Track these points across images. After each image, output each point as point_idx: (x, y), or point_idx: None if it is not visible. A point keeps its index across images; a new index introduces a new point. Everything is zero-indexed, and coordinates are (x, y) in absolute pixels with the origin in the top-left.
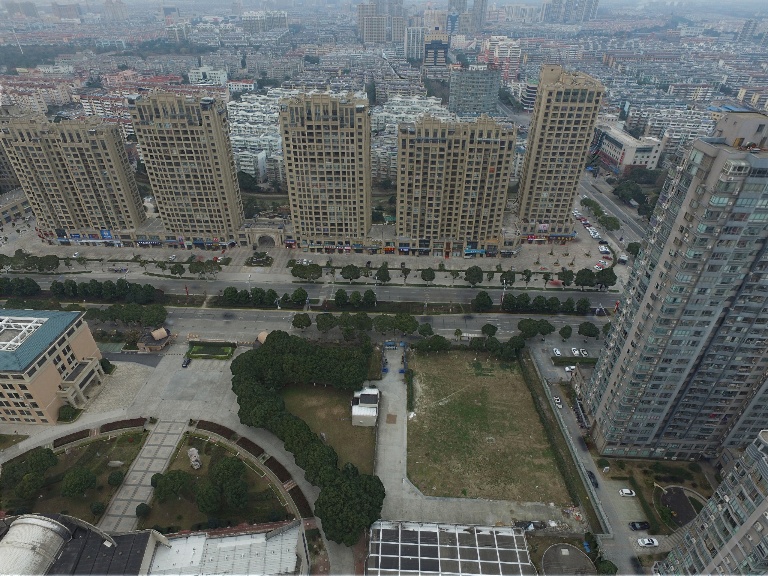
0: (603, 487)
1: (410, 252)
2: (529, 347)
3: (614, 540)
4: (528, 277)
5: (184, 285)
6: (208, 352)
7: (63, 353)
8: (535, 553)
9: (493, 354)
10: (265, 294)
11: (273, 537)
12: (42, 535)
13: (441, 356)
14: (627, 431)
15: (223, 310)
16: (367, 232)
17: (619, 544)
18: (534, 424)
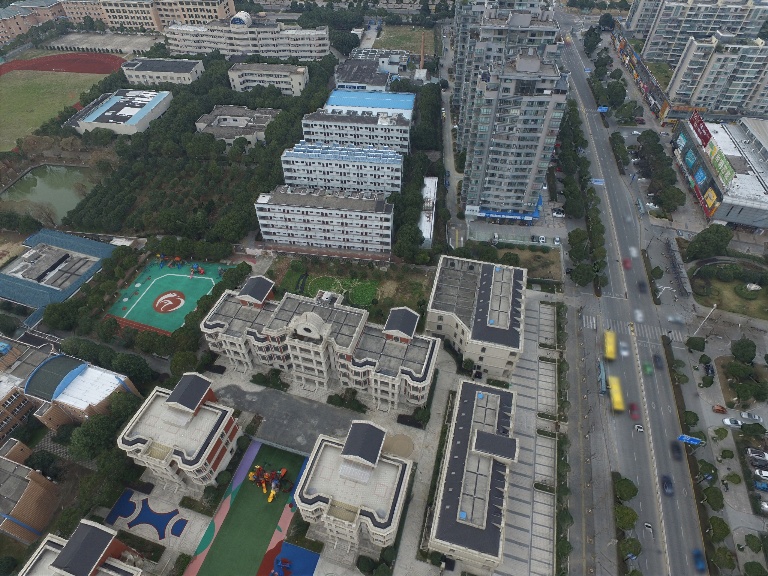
0: (450, 52)
1: None
2: None
3: (445, 59)
4: (454, 2)
5: (268, 6)
6: (285, 23)
7: (226, 5)
8: (413, 60)
9: (423, 26)
10: (312, 5)
11: (318, 30)
12: (247, 16)
13: (397, 27)
14: None
15: (290, 14)
16: None
17: (447, 60)
18: (431, 41)
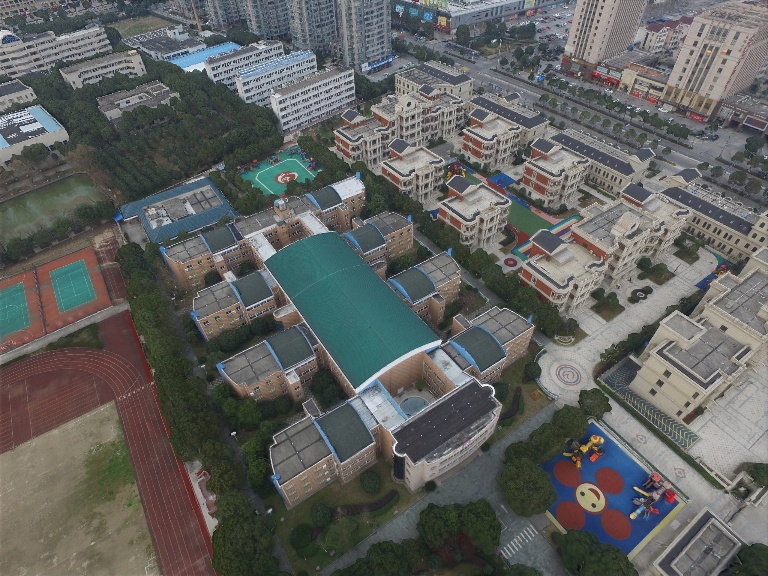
0: None
1: (68, 6)
2: (151, 9)
3: None
4: None
5: None
6: None
7: None
8: None
9: (138, 16)
10: None
11: (88, 29)
12: None
13: None
14: (189, 0)
15: None
16: (34, 1)
17: None
18: None
